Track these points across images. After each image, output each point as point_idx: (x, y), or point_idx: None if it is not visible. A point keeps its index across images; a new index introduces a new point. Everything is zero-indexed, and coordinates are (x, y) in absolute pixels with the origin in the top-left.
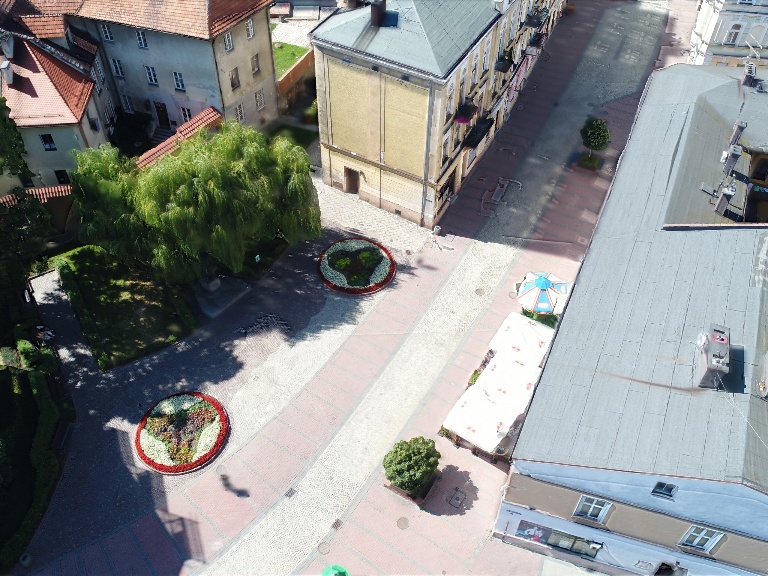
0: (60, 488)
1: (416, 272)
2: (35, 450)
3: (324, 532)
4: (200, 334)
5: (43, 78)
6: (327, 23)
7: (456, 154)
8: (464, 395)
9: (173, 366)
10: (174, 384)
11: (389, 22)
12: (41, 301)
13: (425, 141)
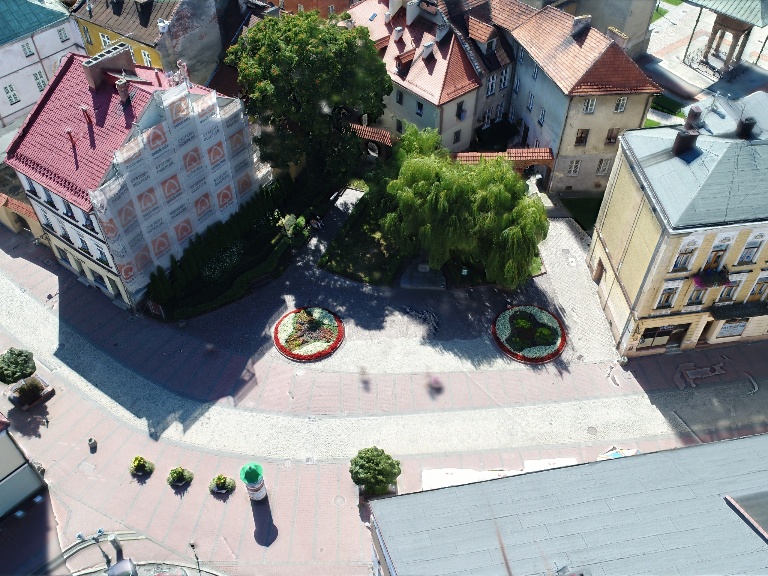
0: (232, 306)
1: (565, 374)
2: (242, 277)
3: (299, 456)
4: (385, 290)
5: (444, 64)
6: (651, 130)
7: (690, 311)
8: (460, 469)
9: (350, 295)
10: (338, 305)
11: (687, 156)
12: (338, 204)
13: (644, 275)
